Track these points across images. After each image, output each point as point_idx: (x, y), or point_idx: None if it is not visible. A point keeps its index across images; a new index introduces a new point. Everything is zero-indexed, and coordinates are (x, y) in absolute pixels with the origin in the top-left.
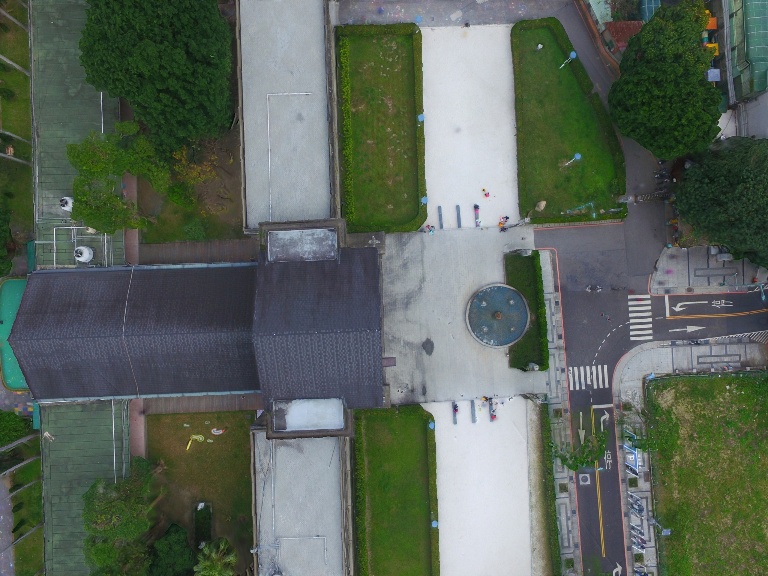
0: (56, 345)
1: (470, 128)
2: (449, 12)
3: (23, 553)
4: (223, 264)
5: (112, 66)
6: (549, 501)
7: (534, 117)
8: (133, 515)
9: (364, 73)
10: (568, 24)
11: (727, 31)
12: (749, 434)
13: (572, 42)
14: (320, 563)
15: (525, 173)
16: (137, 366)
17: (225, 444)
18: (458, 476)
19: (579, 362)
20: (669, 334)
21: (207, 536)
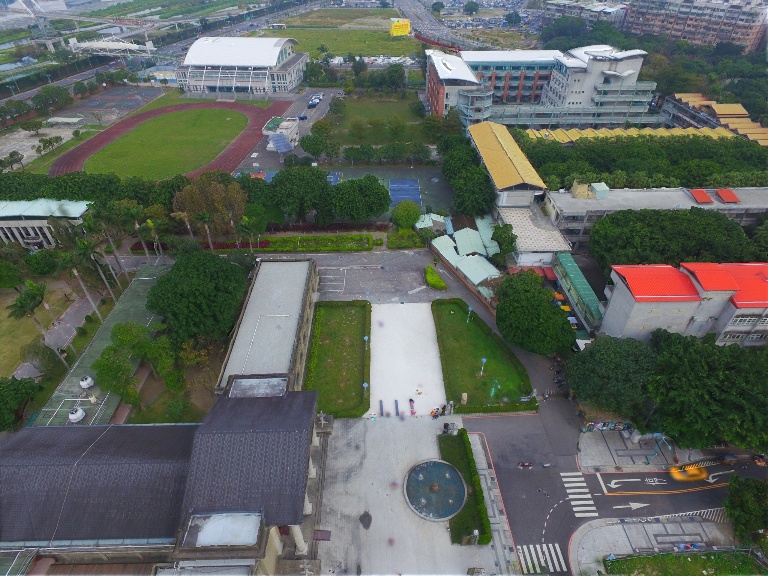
0: (9, 473)
1: (405, 353)
2: (390, 297)
3: None
4: (189, 423)
5: (166, 292)
6: None
7: (452, 347)
8: None
9: (331, 324)
10: (469, 303)
11: (570, 298)
12: None
13: (473, 310)
14: None
15: (450, 380)
16: (70, 501)
17: None
18: None
19: (527, 540)
20: (614, 511)
21: None
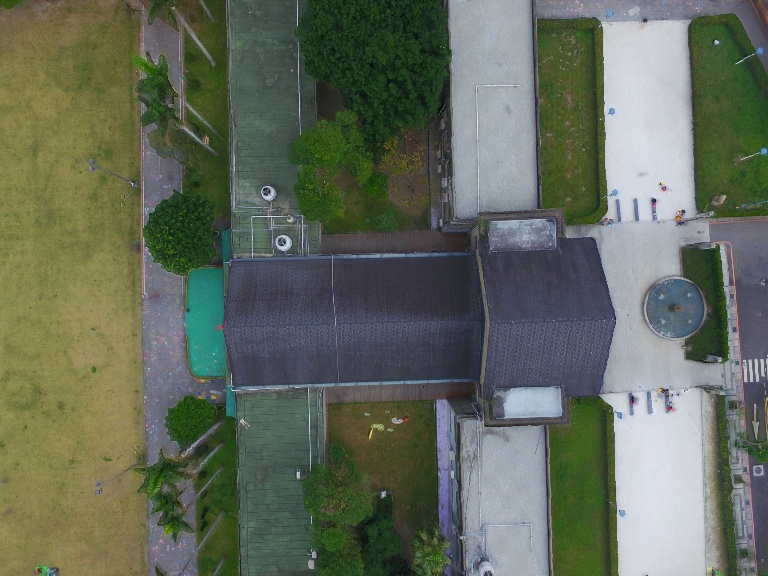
0: (268, 332)
1: (647, 122)
2: (627, 7)
3: (205, 540)
4: (421, 254)
5: (343, 56)
6: (726, 492)
7: (710, 112)
8: (361, 500)
9: (544, 67)
10: (744, 21)
11: None
12: None
13: None
14: (525, 550)
15: None
16: (342, 354)
17: (405, 433)
18: (634, 467)
19: (753, 355)
20: None
21: None
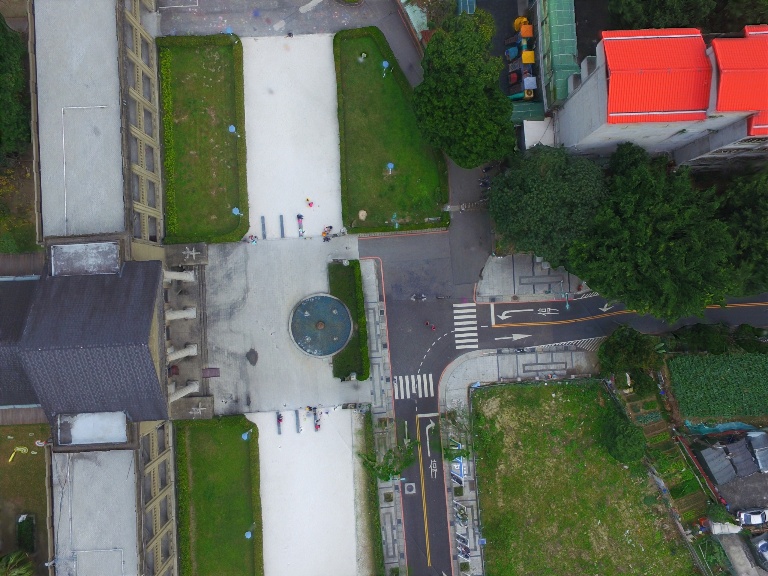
0: None
1: (294, 138)
2: (272, 22)
3: None
4: (30, 277)
5: None
6: (372, 511)
7: (358, 126)
8: None
9: (187, 84)
10: (392, 33)
11: (540, 39)
12: (574, 442)
13: (396, 51)
14: (118, 575)
15: (349, 182)
16: None
17: None
18: (283, 486)
19: (404, 371)
20: (495, 342)
21: (30, 548)
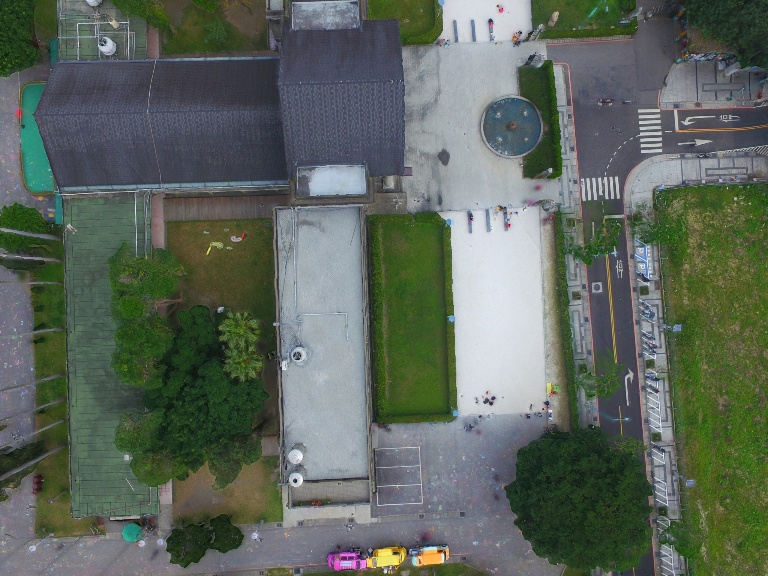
0: (81, 122)
1: None
2: None
3: (43, 357)
4: (245, 57)
5: None
6: (563, 306)
7: None
8: (160, 270)
9: None
10: None
11: None
12: (756, 243)
13: None
14: (341, 339)
15: None
16: (161, 149)
17: (244, 251)
18: (473, 284)
19: (591, 173)
20: (678, 147)
21: None
